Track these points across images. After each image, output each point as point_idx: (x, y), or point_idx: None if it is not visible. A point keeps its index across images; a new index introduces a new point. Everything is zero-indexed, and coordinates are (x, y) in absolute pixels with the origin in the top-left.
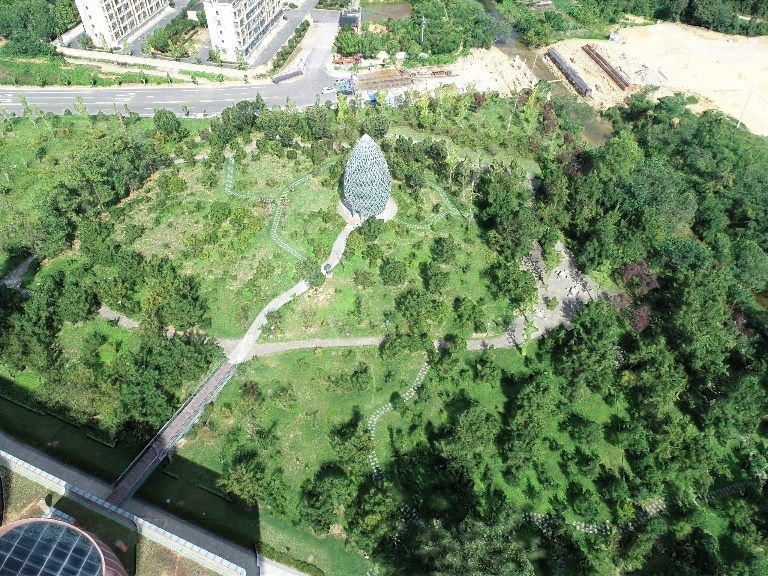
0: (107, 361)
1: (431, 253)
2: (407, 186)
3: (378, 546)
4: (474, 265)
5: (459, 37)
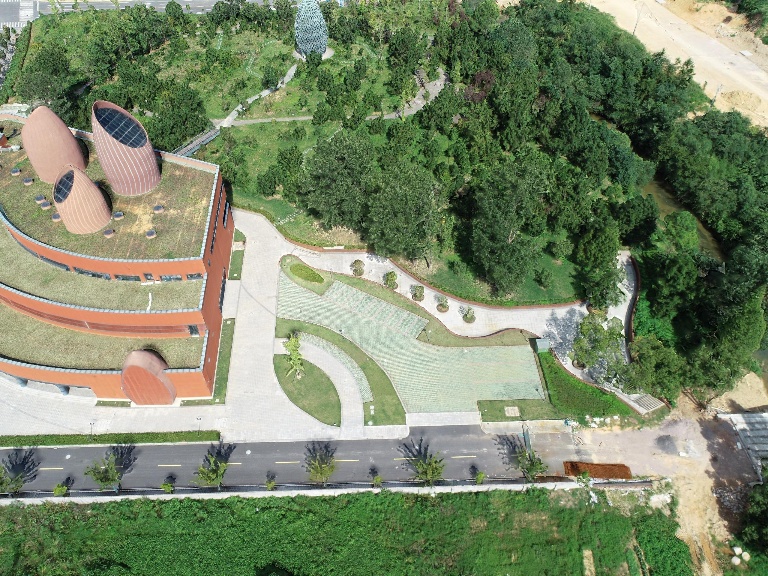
0: None
1: None
2: (343, 43)
3: None
4: (380, 80)
5: None
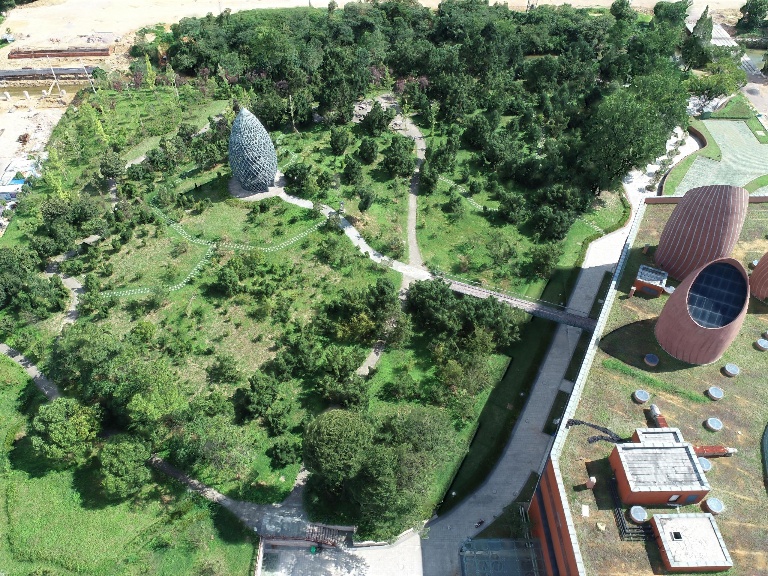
0: (417, 377)
1: (329, 156)
2: None
3: None
4: None
5: None
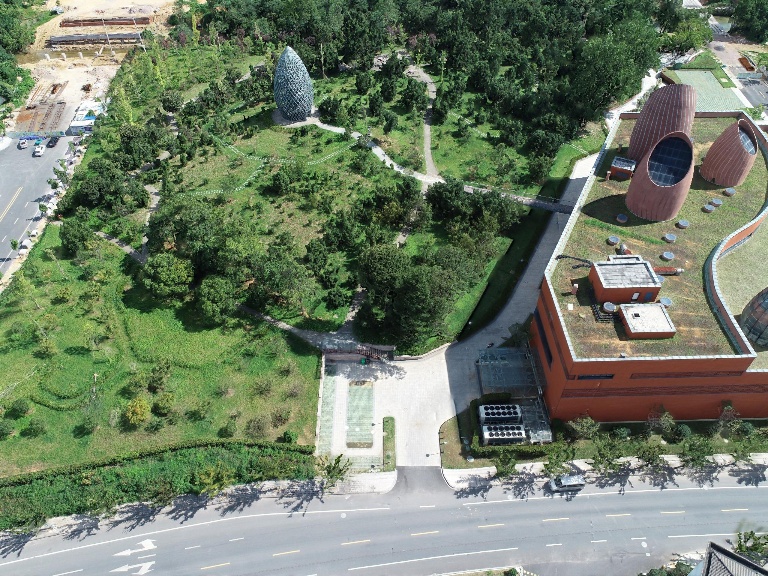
0: None
1: (354, 95)
2: None
3: None
4: None
5: (1, 64)
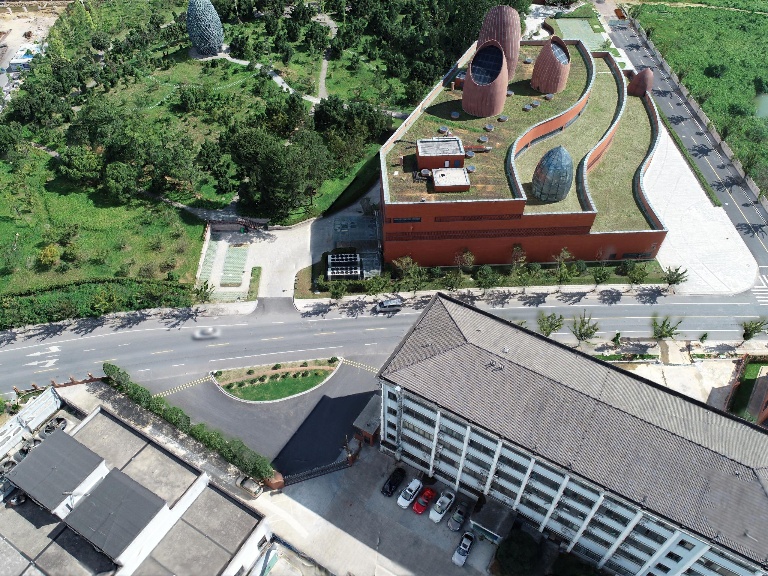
0: None
1: None
2: None
3: (445, 59)
4: None
5: None
